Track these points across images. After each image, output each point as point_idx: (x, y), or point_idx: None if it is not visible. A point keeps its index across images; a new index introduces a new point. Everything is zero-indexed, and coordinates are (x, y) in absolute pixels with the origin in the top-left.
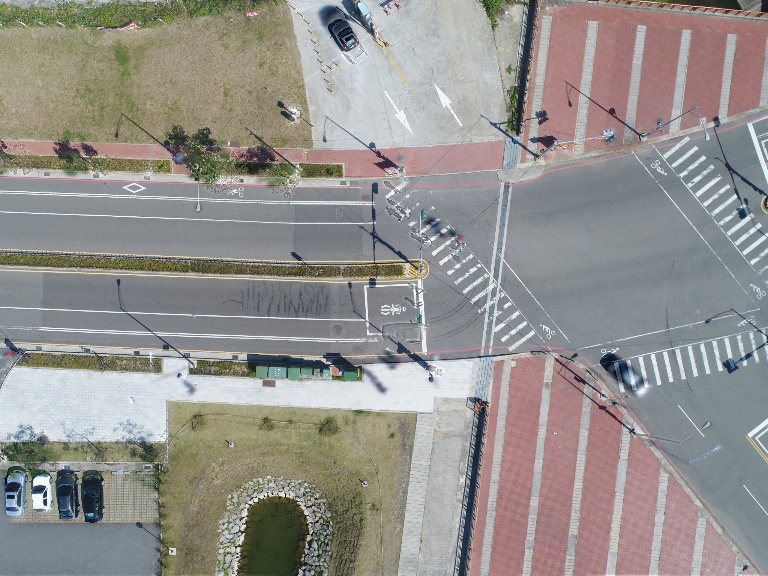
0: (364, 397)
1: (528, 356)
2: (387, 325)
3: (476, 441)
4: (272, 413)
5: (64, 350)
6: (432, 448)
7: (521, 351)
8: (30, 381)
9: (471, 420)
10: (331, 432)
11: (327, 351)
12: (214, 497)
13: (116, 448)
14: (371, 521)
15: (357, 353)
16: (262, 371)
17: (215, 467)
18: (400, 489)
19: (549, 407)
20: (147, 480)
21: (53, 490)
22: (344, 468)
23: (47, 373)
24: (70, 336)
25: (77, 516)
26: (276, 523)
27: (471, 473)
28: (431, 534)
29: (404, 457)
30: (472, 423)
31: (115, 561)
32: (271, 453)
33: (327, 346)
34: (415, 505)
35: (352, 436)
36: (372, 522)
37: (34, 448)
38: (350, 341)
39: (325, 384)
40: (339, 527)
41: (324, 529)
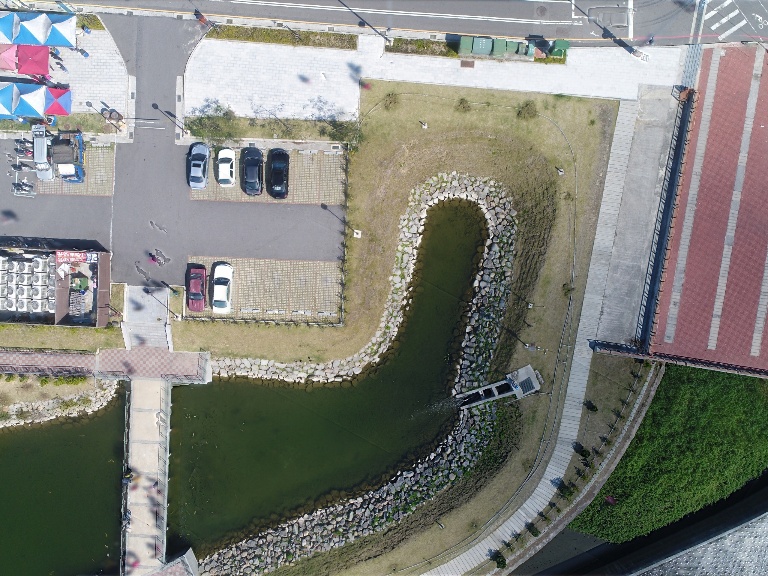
0: (566, 81)
1: (738, 46)
2: (593, 9)
3: (679, 132)
4: (469, 94)
5: (256, 24)
6: (633, 138)
7: (731, 40)
8: (219, 54)
9: (675, 110)
10: (530, 115)
11: (529, 33)
12: (398, 188)
13: (305, 126)
14: (565, 211)
15: (561, 36)
16: (467, 41)
17: (405, 151)
18: (597, 179)
19: (757, 99)
20: (334, 160)
21: (236, 168)
22: (540, 155)
23: (237, 46)
24: (263, 9)
25: (261, 193)
26: (454, 229)
27: (671, 166)
28: (626, 227)
29: (603, 145)
30: (676, 114)
31: (297, 243)
32: (463, 139)
33: (530, 28)
34: (612, 196)
35: (551, 120)
36: (566, 212)
37: (219, 123)
38: (554, 23)
39: (526, 66)
40: (526, 224)
41: (508, 230)
